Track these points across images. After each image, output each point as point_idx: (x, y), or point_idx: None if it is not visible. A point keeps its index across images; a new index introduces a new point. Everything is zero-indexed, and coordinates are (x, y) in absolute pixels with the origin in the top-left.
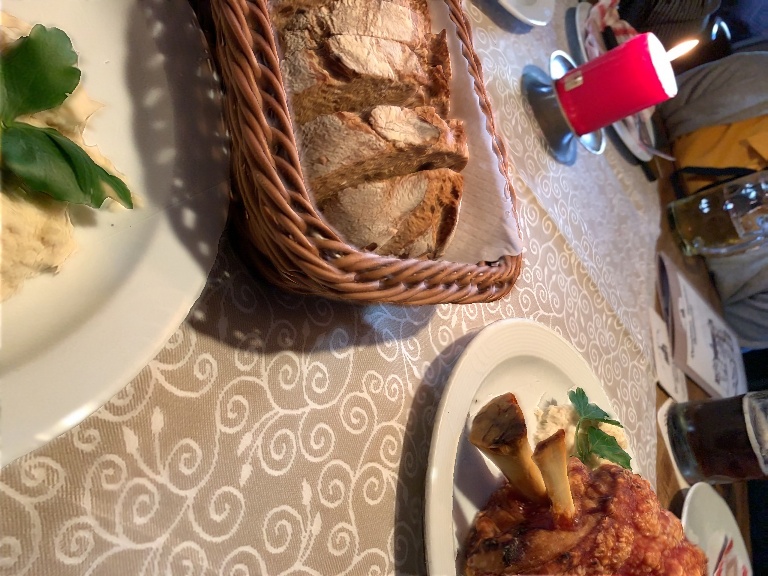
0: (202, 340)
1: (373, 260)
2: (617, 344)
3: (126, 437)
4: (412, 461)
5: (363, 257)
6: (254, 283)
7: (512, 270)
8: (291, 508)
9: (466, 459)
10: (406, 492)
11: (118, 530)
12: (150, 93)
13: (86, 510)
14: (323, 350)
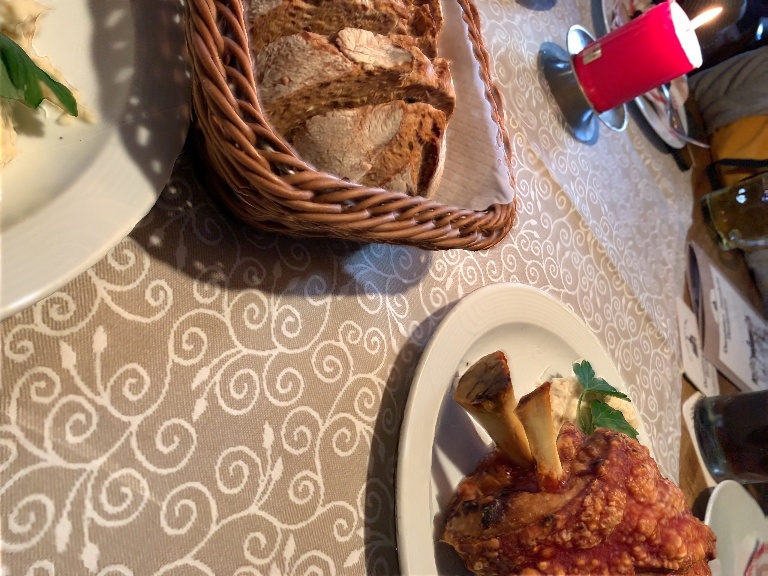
0: (156, 266)
1: (331, 180)
2: (638, 329)
3: (62, 352)
4: (391, 418)
5: (320, 176)
6: (222, 219)
7: (501, 218)
8: (249, 450)
9: (454, 423)
10: (383, 449)
11: (47, 445)
12: (112, 14)
13: (10, 419)
14: (296, 294)
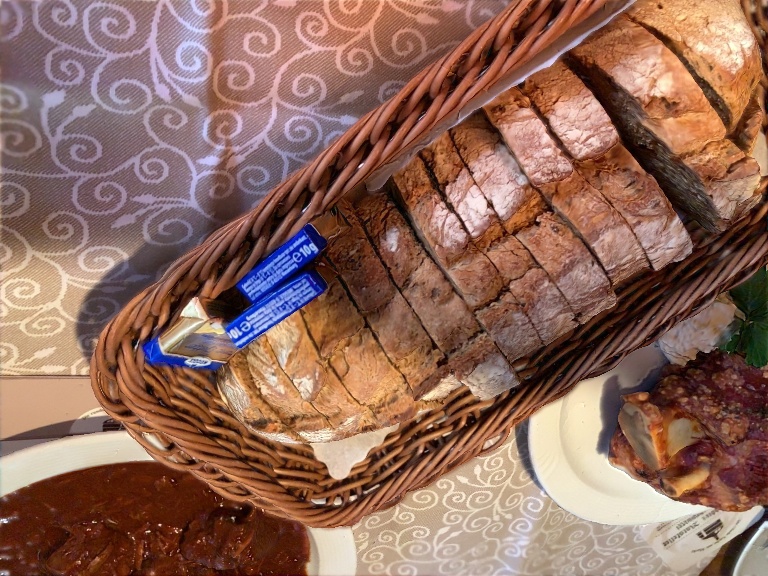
0: None
1: None
2: None
3: None
4: None
5: None
6: None
7: None
8: None
9: None
10: None
11: None
12: None
13: None
14: None
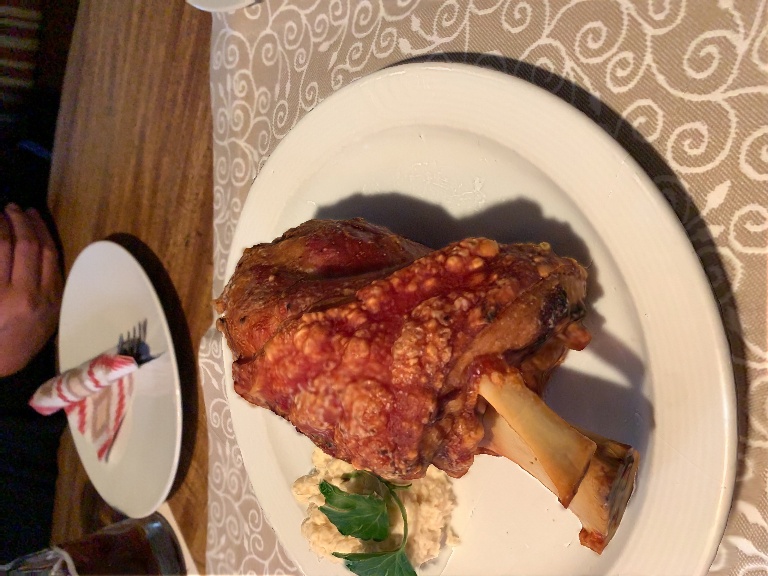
0: None
1: None
2: None
3: None
4: None
5: None
6: None
7: None
8: None
9: None
10: None
11: None
12: None
13: None
14: None
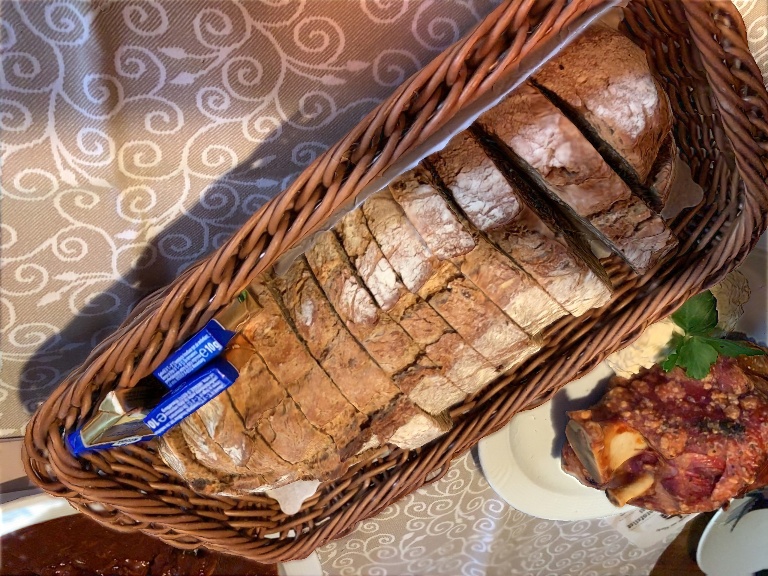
0: None
1: (763, 190)
2: None
3: None
4: None
5: (762, 198)
6: None
7: None
8: None
9: None
10: None
11: None
12: None
13: None
14: None
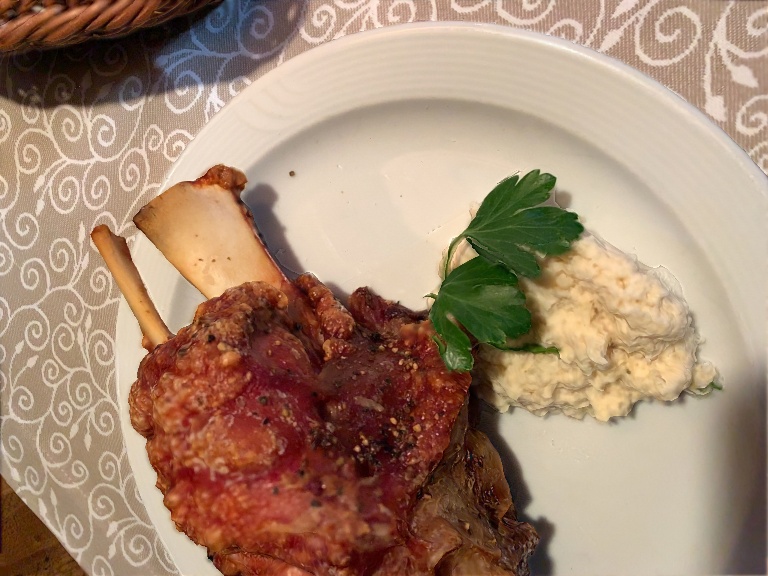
0: None
1: None
2: None
3: None
4: None
5: None
6: None
7: None
8: (70, 242)
9: None
10: None
11: None
12: None
13: None
14: (109, 102)
